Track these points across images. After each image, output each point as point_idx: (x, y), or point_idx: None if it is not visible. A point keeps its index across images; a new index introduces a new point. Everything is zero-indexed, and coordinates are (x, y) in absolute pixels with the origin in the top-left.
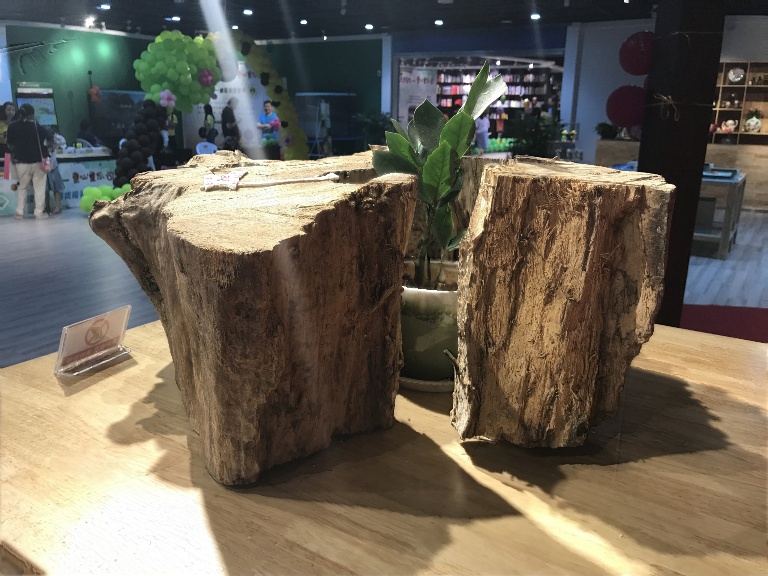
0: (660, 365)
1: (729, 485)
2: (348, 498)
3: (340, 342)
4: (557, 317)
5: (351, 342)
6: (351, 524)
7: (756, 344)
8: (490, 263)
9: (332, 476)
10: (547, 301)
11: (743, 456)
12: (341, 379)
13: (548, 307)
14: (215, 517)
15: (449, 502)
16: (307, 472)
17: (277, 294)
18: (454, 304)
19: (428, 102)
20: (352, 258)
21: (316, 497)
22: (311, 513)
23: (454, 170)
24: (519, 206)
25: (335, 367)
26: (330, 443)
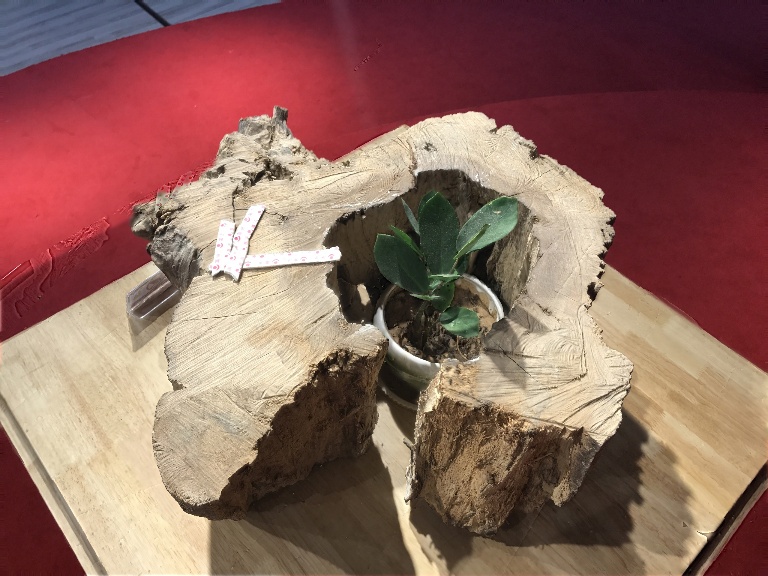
0: (641, 401)
1: None
2: (306, 541)
3: (314, 433)
4: (479, 487)
5: (324, 431)
6: (300, 571)
7: (763, 379)
8: (438, 425)
9: (303, 510)
10: (478, 466)
11: (628, 560)
12: (317, 446)
13: (478, 471)
14: (215, 540)
15: (374, 563)
16: (286, 501)
17: (231, 499)
18: (434, 375)
19: (440, 195)
20: (320, 401)
21: (285, 534)
22: (277, 552)
23: None
24: (460, 417)
25: (311, 443)
26: (310, 472)
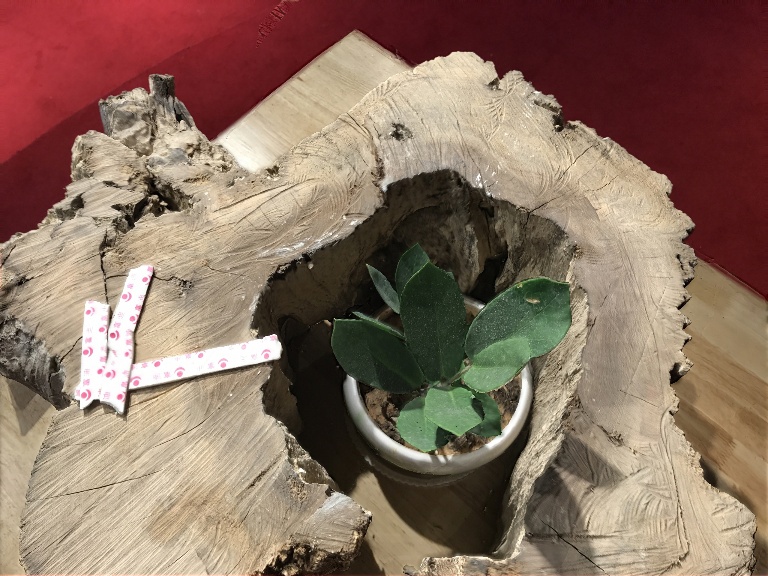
0: (703, 428)
1: None
2: None
3: None
4: None
5: None
6: None
7: None
8: None
9: None
10: None
11: None
12: None
13: None
14: None
15: None
16: None
17: None
18: (437, 469)
19: (431, 266)
20: None
21: None
22: None
23: None
24: None
25: None
26: None
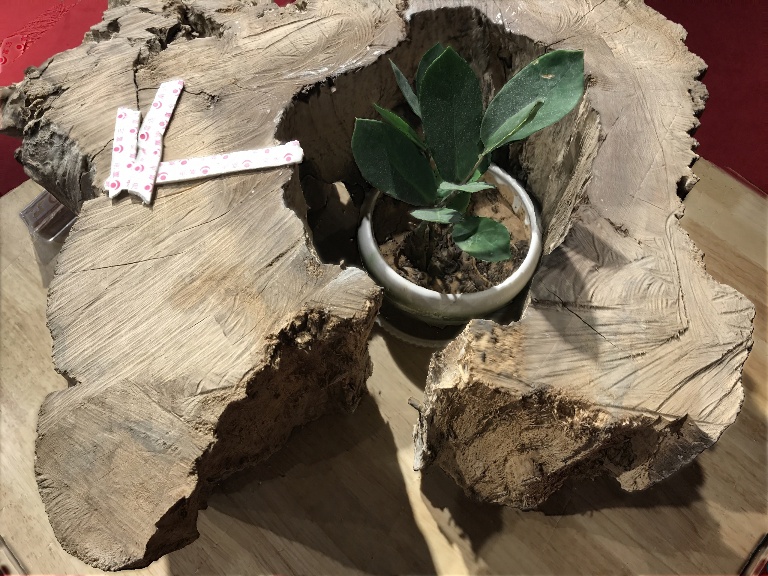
0: None
1: (656, 571)
2: (290, 529)
3: None
4: (520, 476)
5: None
6: (285, 568)
7: None
8: (460, 401)
9: (283, 487)
10: None
11: (699, 523)
12: None
13: (517, 454)
14: None
15: (379, 550)
16: (261, 477)
17: (169, 538)
18: (445, 309)
19: (452, 51)
20: (288, 375)
21: (262, 521)
22: (254, 546)
23: (458, 218)
24: (498, 404)
25: (285, 413)
26: (289, 437)
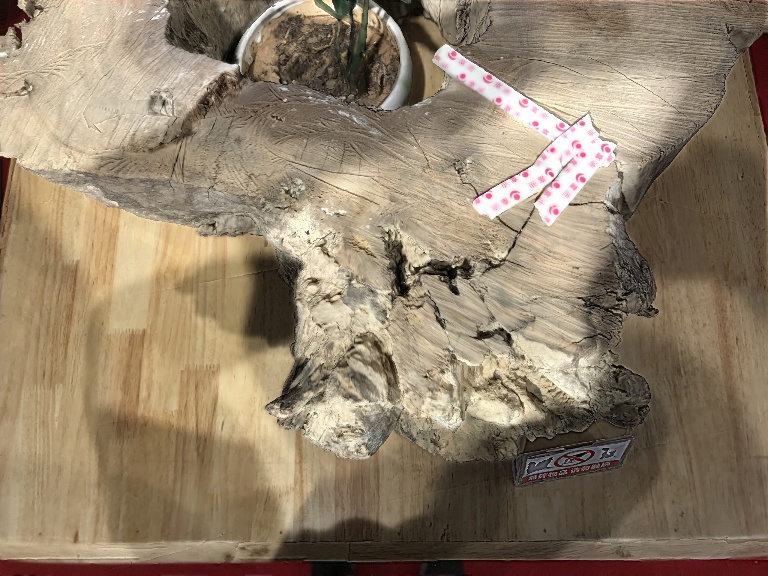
0: None
1: None
2: None
3: None
4: None
5: None
6: None
7: None
8: None
9: None
10: None
11: None
12: None
13: None
14: None
15: None
16: None
17: None
18: None
19: None
20: None
21: None
22: None
23: None
24: None
25: None
26: None
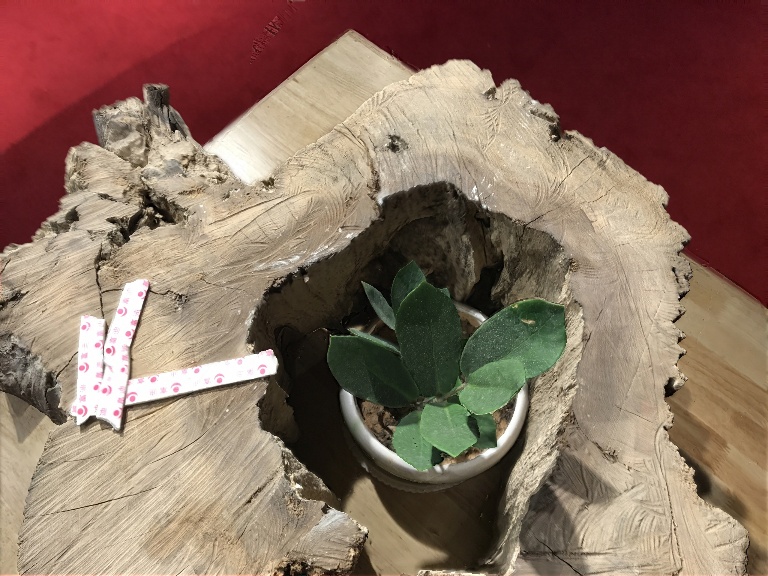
0: (697, 433)
1: None
2: None
3: None
4: None
5: None
6: None
7: None
8: None
9: None
10: None
11: None
12: None
13: None
14: None
15: None
16: None
17: None
18: (433, 479)
19: (427, 284)
20: None
21: None
22: None
23: None
24: None
25: None
26: None
